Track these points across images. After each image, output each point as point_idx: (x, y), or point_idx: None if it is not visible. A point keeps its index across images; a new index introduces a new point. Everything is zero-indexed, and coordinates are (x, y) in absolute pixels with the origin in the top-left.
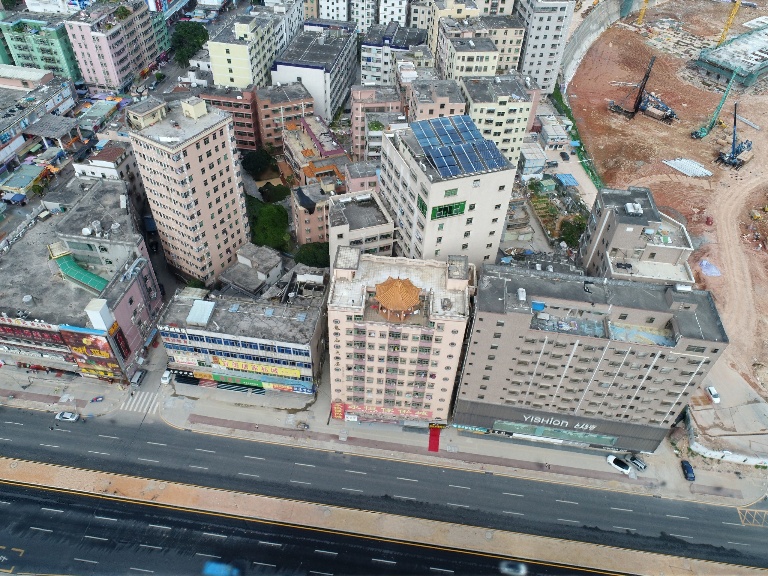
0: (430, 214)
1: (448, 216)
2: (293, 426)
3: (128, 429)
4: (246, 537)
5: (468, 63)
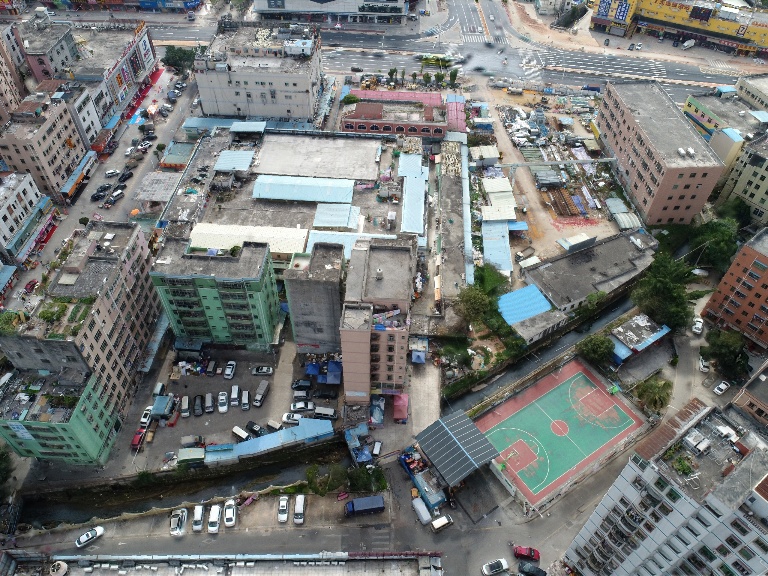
0: None
1: None
2: None
3: None
4: None
5: None
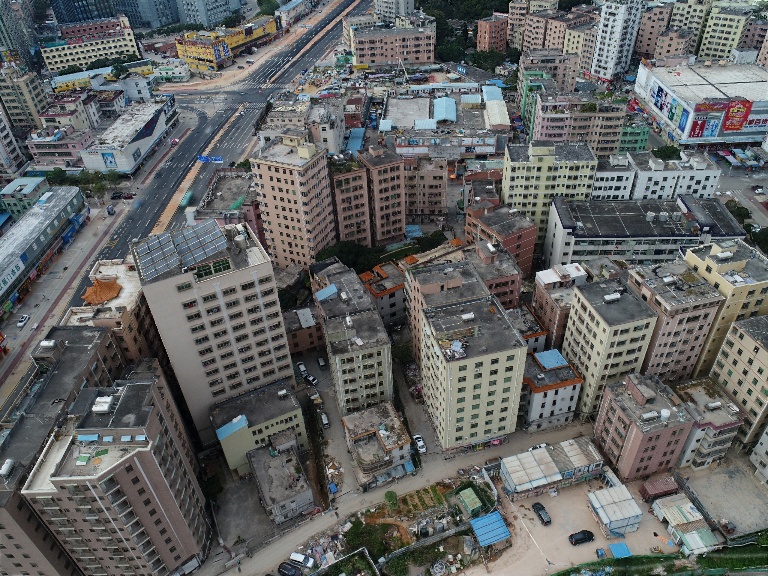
0: None
1: None
2: None
3: None
4: None
5: (581, 310)
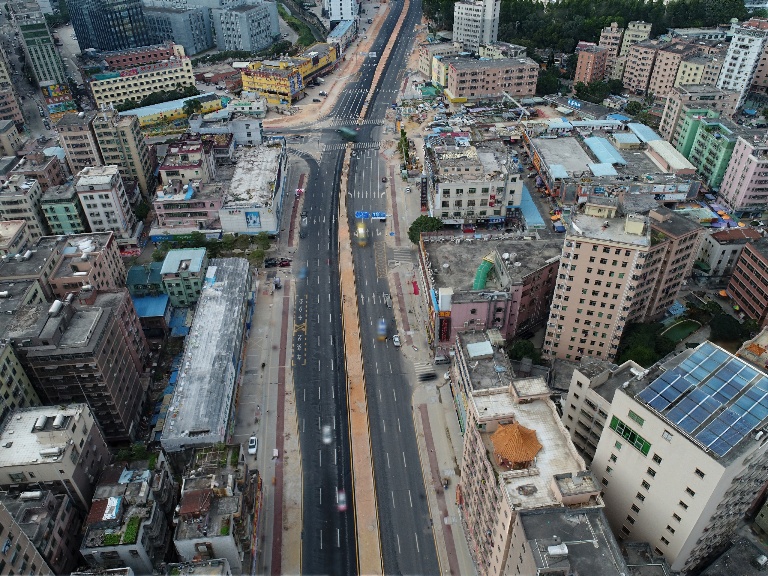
0: (610, 419)
1: (629, 441)
2: (443, 476)
3: (400, 375)
4: (338, 476)
5: None
